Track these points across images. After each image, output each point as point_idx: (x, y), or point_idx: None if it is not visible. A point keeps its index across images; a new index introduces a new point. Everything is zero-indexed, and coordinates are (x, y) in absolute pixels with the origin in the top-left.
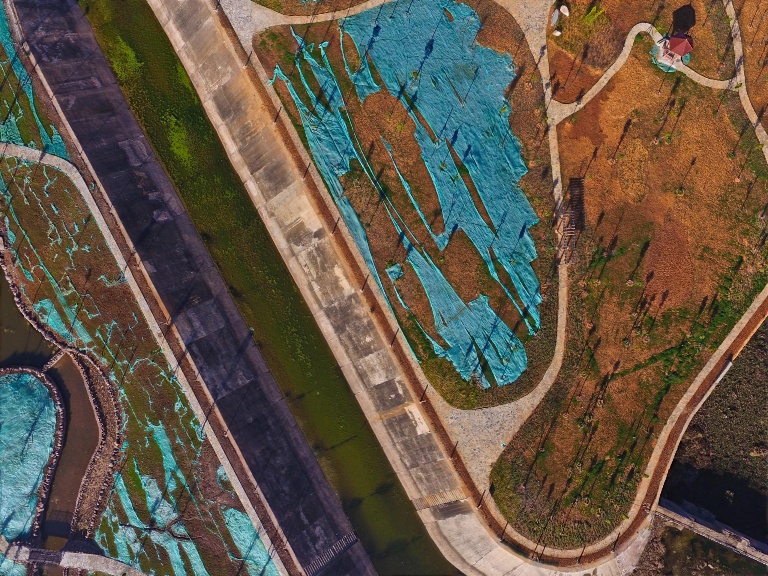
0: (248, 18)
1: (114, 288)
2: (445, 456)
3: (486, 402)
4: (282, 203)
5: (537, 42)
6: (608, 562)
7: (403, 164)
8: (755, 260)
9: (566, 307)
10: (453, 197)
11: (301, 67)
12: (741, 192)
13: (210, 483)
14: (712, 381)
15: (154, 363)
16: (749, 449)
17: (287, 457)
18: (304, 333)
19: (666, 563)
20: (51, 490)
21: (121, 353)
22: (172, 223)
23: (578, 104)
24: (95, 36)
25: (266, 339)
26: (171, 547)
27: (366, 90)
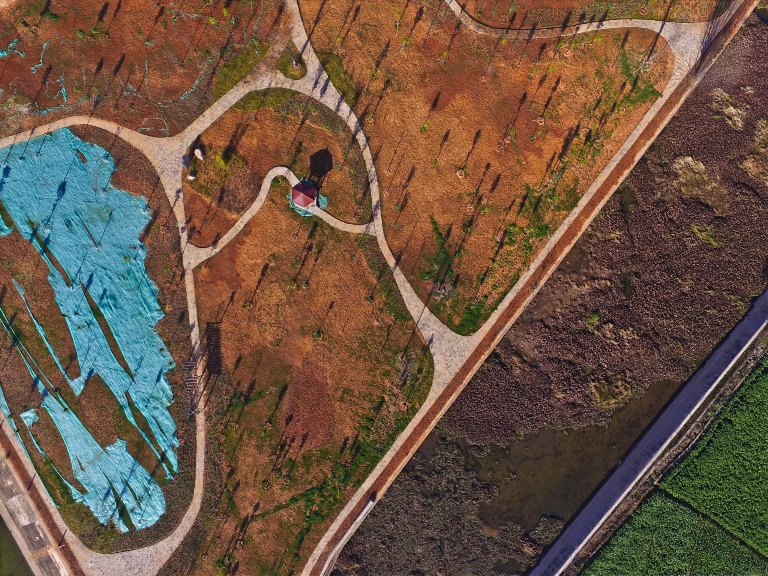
0: None
1: None
2: None
3: (125, 546)
4: None
5: (172, 185)
6: None
7: (37, 308)
8: (397, 400)
9: (204, 451)
10: (88, 341)
11: None
12: (381, 334)
13: None
14: (353, 519)
15: None
16: None
17: None
18: None
19: None
20: None
21: None
22: None
23: (214, 248)
24: None
25: None
26: None
27: None
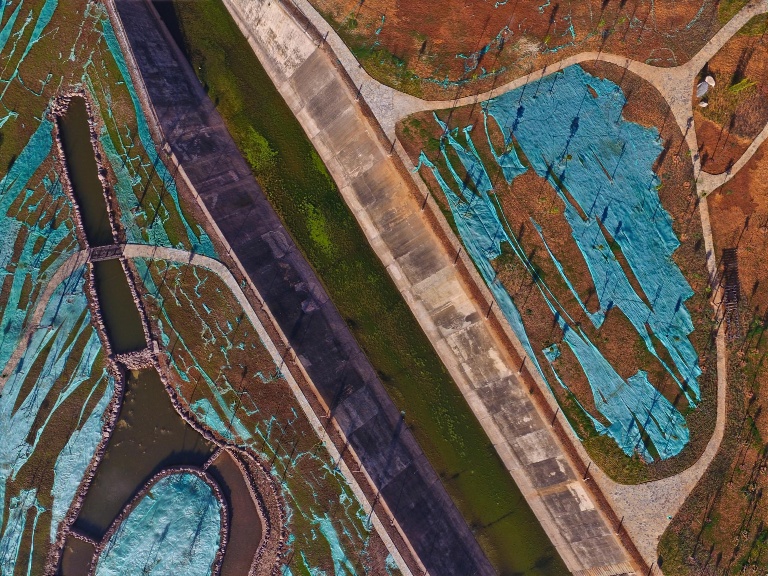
0: (390, 106)
1: (271, 384)
2: (611, 532)
3: (650, 476)
4: (430, 287)
5: (683, 114)
6: None
7: (554, 244)
8: None
9: (725, 378)
10: (606, 274)
11: (446, 153)
12: None
13: (379, 572)
14: None
15: (316, 457)
16: None
17: (449, 539)
18: (455, 413)
19: None
20: None
21: (282, 448)
22: (319, 313)
23: (728, 174)
24: (227, 128)
25: (417, 421)
26: None
27: (513, 172)
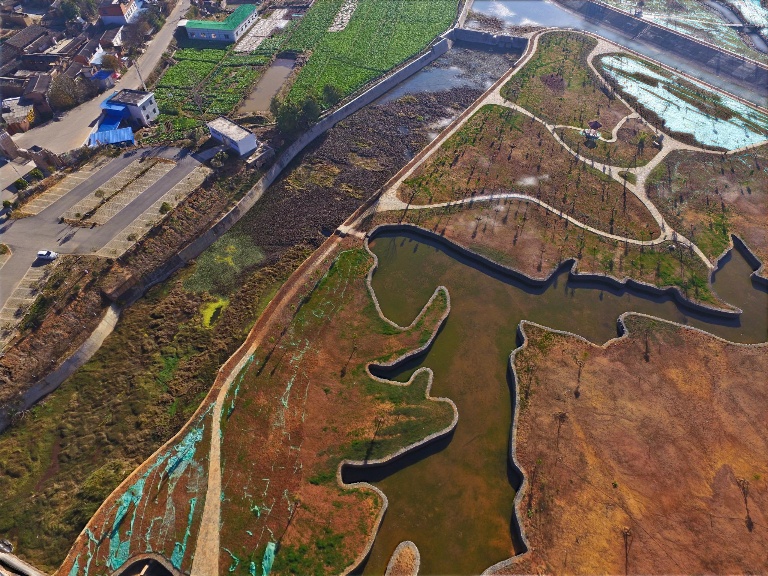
0: None
1: None
2: (618, 44)
3: None
4: None
5: None
6: None
7: None
8: None
9: None
10: (666, 94)
11: None
12: None
13: None
14: (520, 61)
15: (754, 58)
16: (487, 58)
17: None
18: None
19: None
20: None
21: None
22: None
23: None
24: None
25: None
26: None
27: None
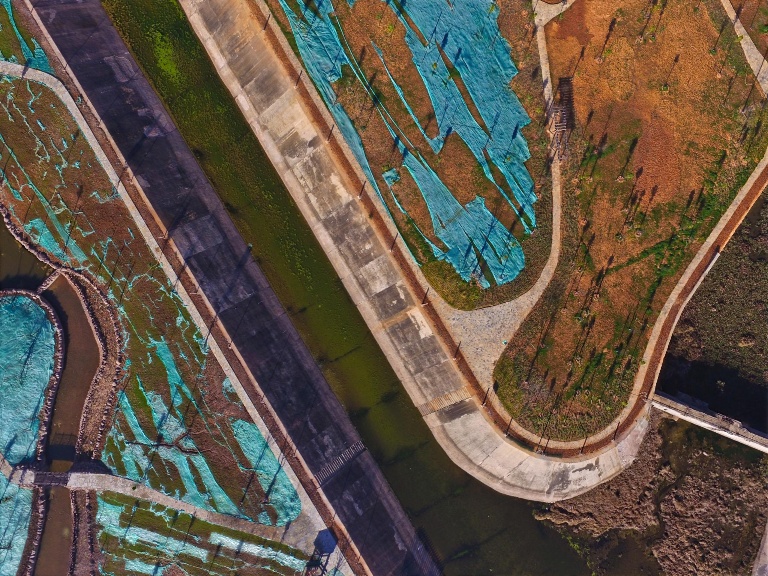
0: None
1: (107, 204)
2: (449, 357)
3: (486, 302)
4: (275, 115)
5: None
6: (609, 451)
7: (395, 69)
8: (738, 154)
9: (560, 205)
10: (446, 100)
11: None
12: (723, 88)
13: (216, 396)
14: (701, 272)
15: (153, 278)
16: (737, 340)
17: (292, 369)
18: (303, 247)
19: (663, 453)
20: (53, 414)
21: (118, 270)
22: (163, 139)
23: (564, 4)
24: None
25: (265, 254)
26: (180, 462)
27: None
